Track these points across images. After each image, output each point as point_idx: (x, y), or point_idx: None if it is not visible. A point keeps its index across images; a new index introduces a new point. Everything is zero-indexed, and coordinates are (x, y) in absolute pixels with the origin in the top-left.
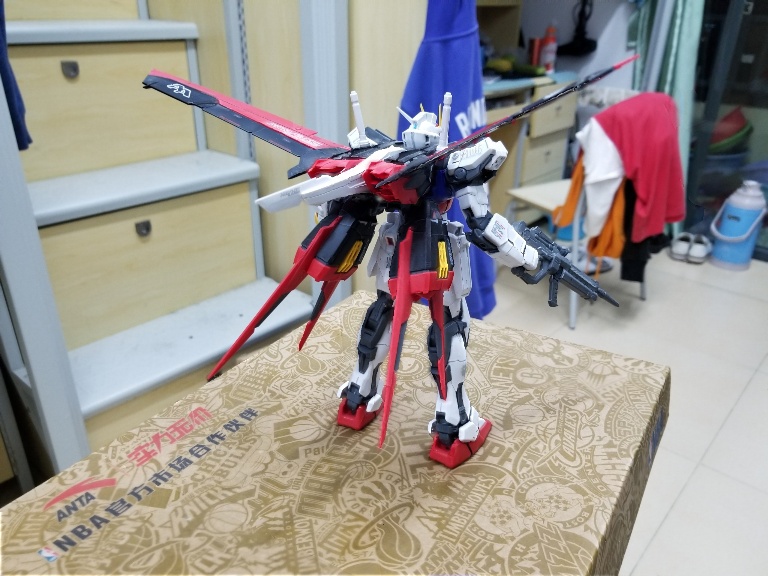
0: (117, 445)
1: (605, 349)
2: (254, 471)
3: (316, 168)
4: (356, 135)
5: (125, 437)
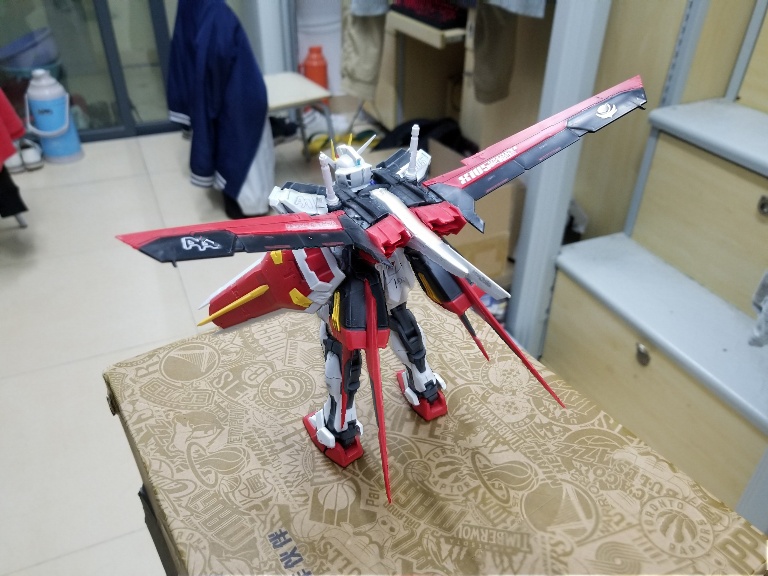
0: None
1: None
2: (376, 555)
3: None
4: (293, 195)
5: None
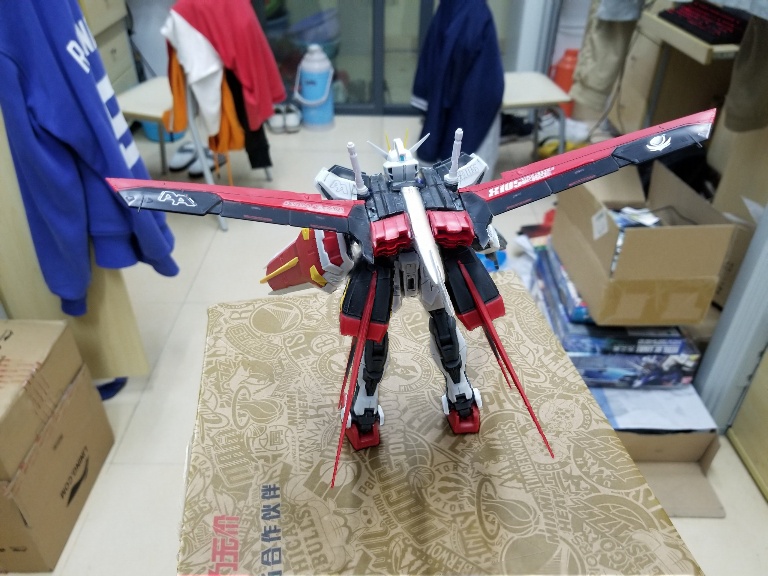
0: None
1: None
2: (343, 538)
3: (378, 240)
4: (330, 178)
5: None
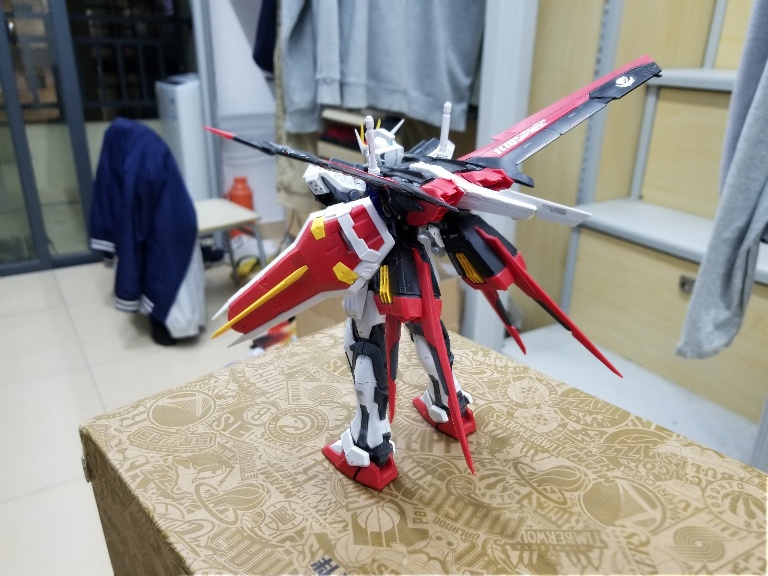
0: None
1: None
2: (440, 570)
3: None
4: None
5: None
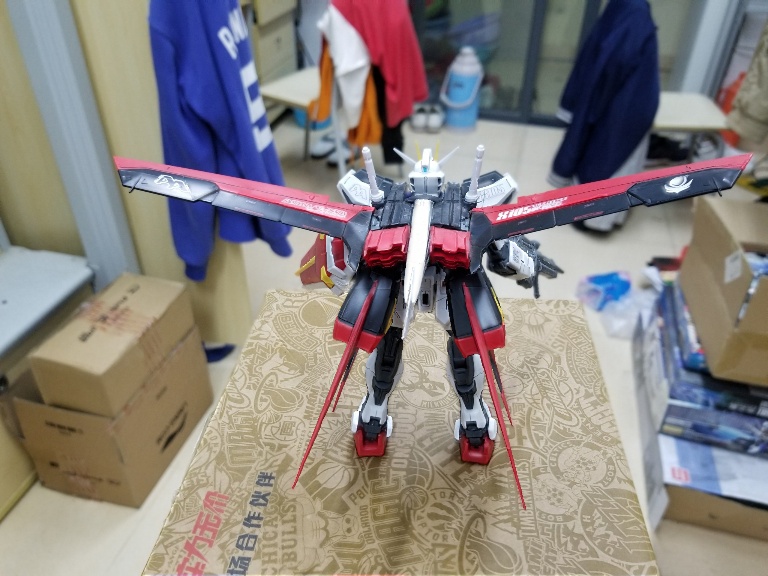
0: (153, 575)
1: (525, 297)
2: (319, 541)
3: (369, 249)
4: (351, 182)
5: (155, 562)
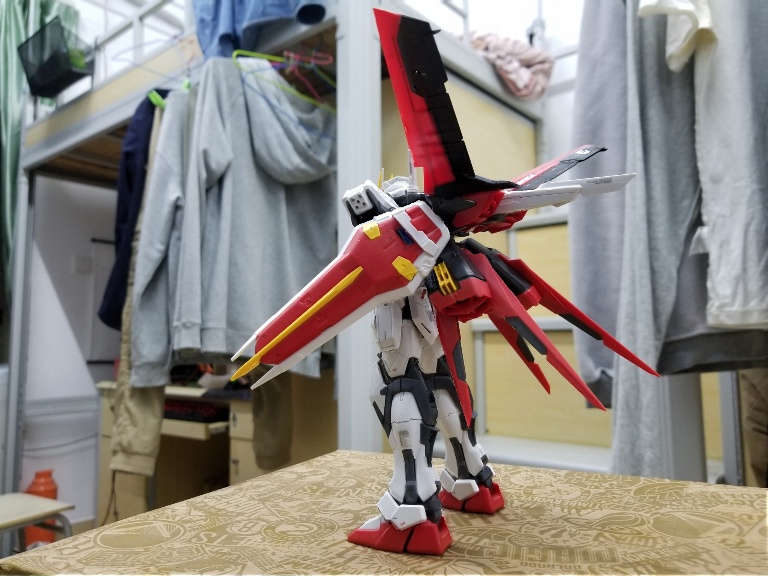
0: None
1: None
2: None
3: None
4: None
5: None
